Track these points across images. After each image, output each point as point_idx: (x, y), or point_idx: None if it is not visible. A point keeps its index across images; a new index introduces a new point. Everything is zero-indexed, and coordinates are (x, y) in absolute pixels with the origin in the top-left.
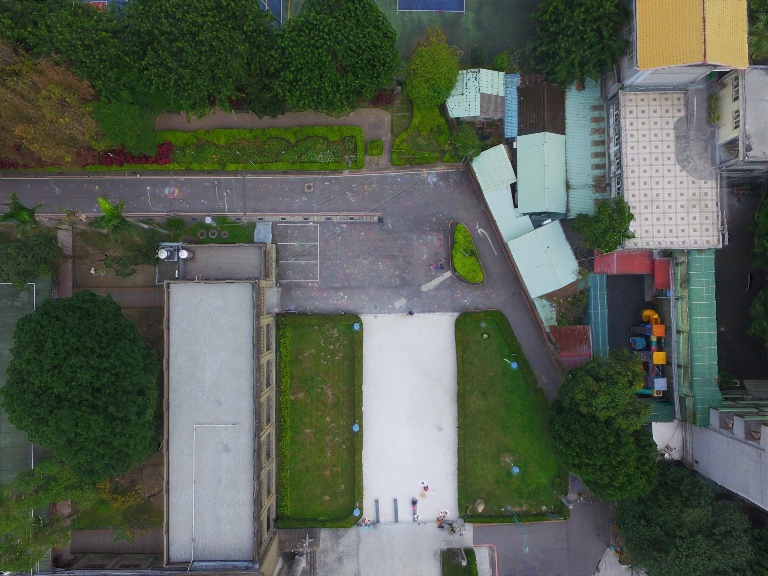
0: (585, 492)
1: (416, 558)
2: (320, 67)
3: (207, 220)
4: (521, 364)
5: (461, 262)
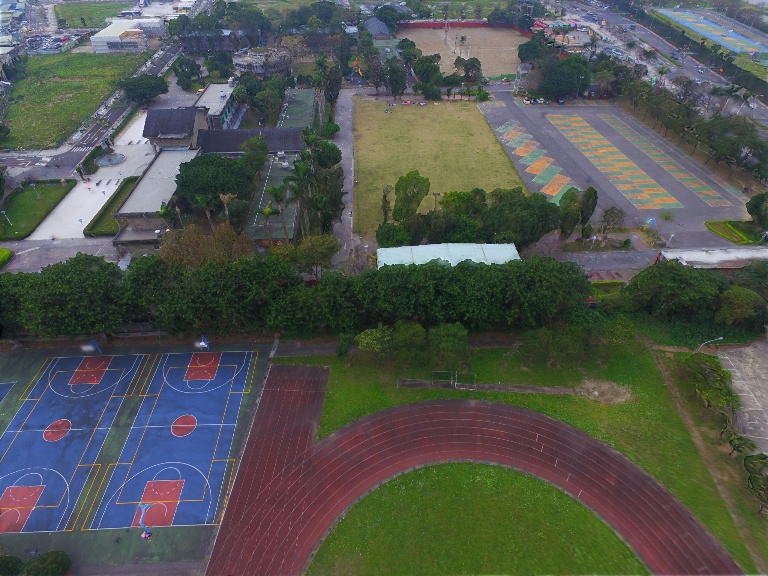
0: (8, 190)
1: (108, 172)
2: (3, 276)
3: (146, 254)
4: (3, 222)
5: (4, 253)
